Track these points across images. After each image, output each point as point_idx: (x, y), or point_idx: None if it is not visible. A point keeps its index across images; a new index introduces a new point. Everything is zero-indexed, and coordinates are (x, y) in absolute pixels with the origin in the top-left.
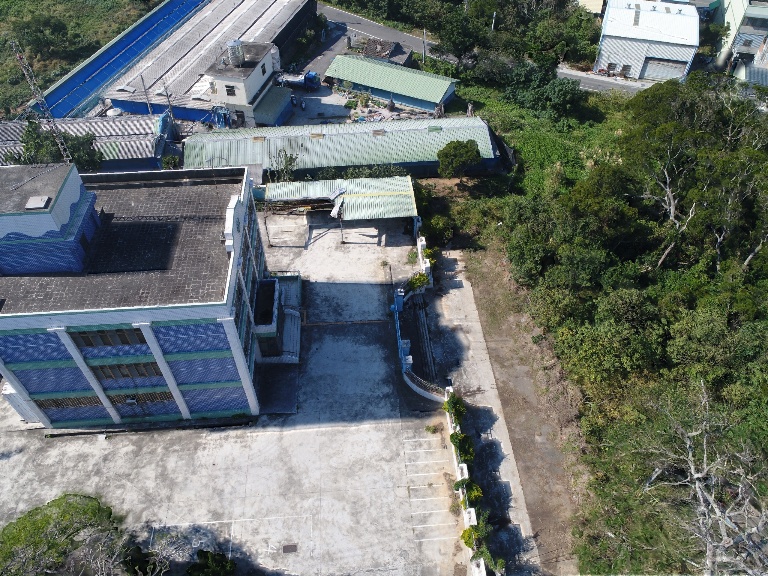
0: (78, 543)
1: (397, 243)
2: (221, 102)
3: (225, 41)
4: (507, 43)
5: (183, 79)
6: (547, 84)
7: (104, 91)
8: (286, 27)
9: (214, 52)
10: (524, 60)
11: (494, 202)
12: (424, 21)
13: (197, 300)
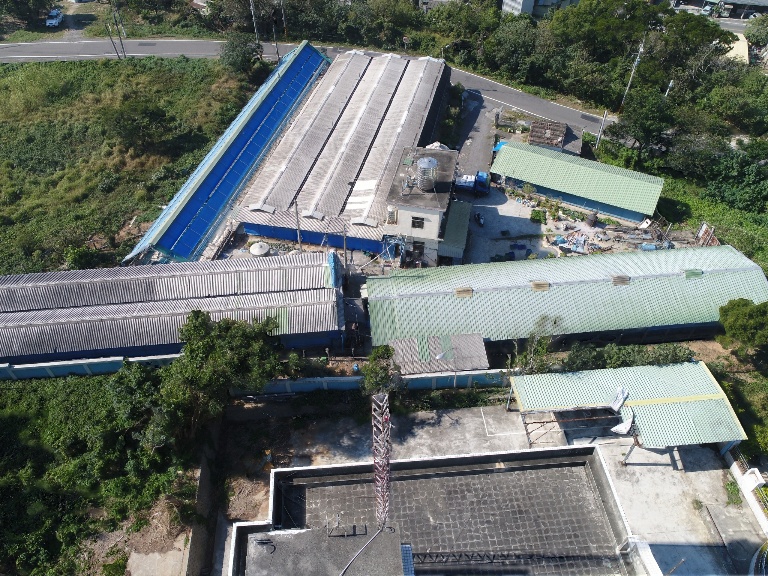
0: None
1: (700, 464)
2: (400, 234)
3: (365, 131)
4: (710, 127)
5: (332, 192)
6: (764, 179)
7: (233, 210)
8: (431, 107)
9: (357, 148)
10: (730, 147)
11: None
12: (573, 87)
13: None
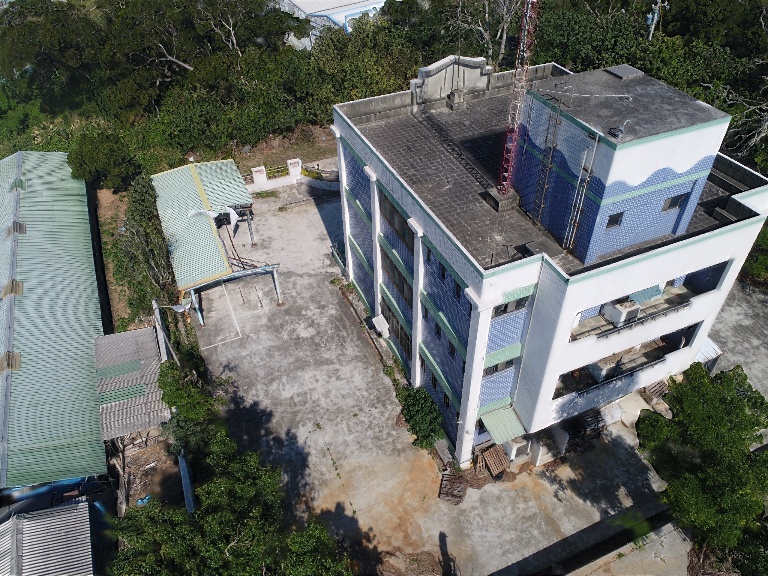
0: (759, 154)
1: None
2: None
3: None
4: None
5: None
6: None
7: None
8: None
9: None
10: None
11: (152, 166)
12: None
13: None
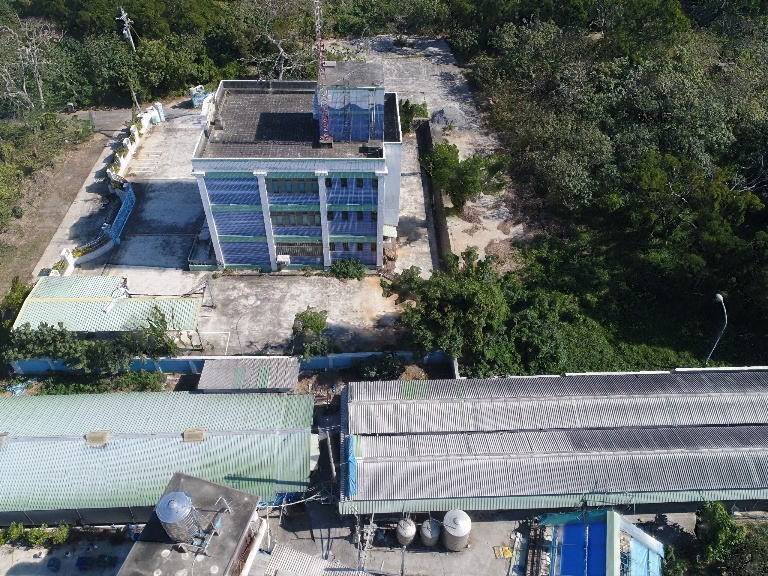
0: None
1: None
2: None
3: None
4: None
5: None
6: None
7: None
8: None
9: None
10: None
11: None
12: None
13: (243, 99)
